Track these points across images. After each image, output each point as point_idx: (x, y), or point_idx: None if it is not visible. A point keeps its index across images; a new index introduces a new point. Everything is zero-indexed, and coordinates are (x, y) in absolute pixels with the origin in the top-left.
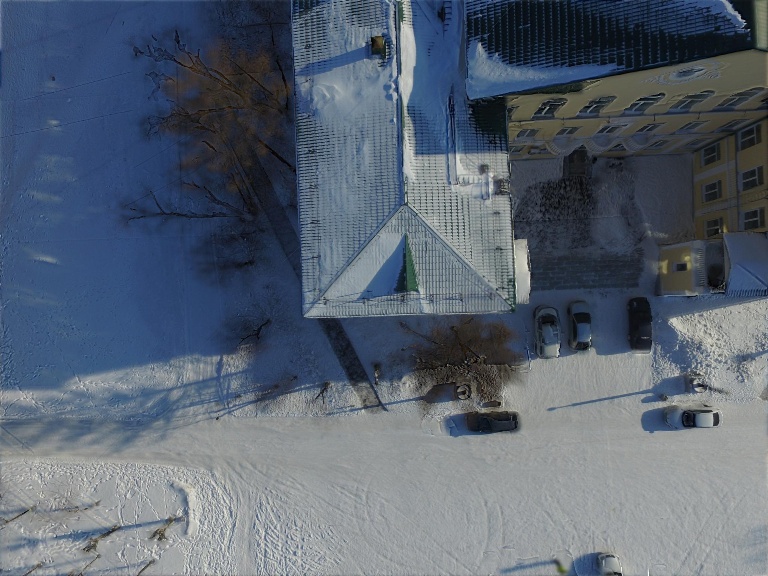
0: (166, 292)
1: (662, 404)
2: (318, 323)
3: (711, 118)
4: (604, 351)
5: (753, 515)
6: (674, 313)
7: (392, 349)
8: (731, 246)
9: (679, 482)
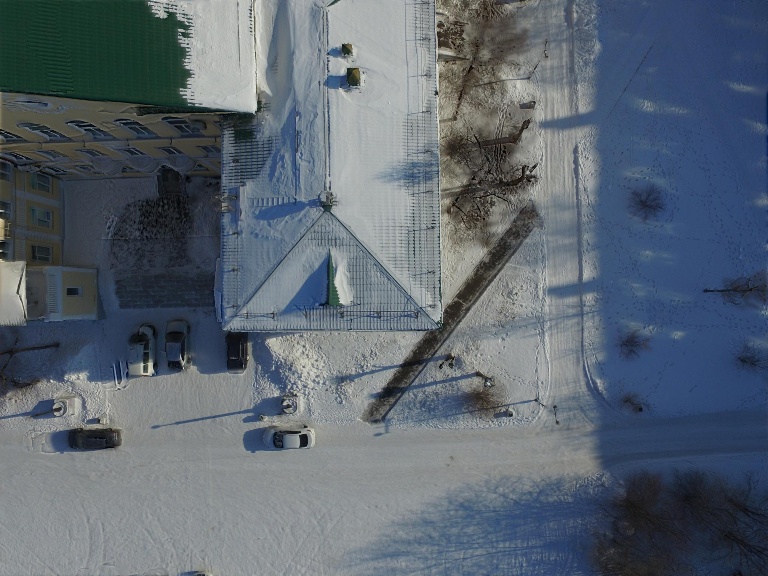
0: None
1: (263, 424)
2: None
3: (207, 143)
4: (198, 370)
5: (349, 537)
6: (275, 333)
7: None
8: (218, 272)
9: (277, 502)
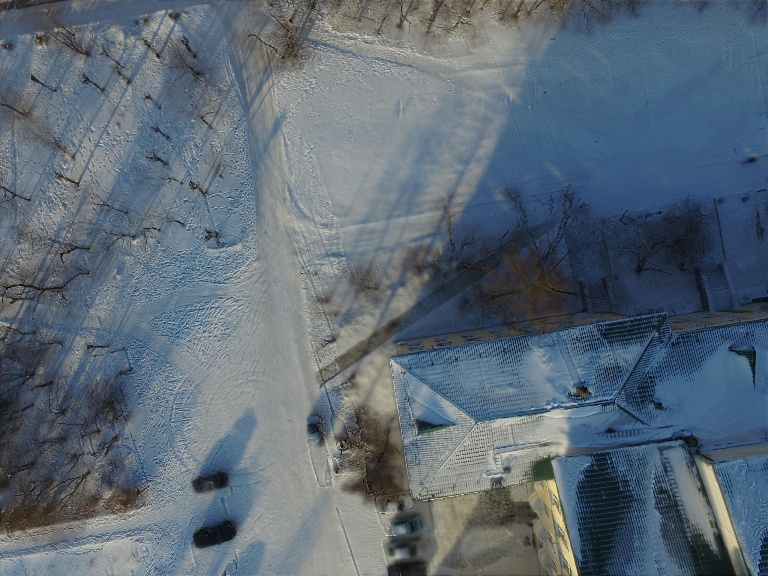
0: (388, 206)
1: None
2: (380, 327)
3: None
4: (387, 546)
5: None
6: None
7: (367, 386)
8: None
9: None
